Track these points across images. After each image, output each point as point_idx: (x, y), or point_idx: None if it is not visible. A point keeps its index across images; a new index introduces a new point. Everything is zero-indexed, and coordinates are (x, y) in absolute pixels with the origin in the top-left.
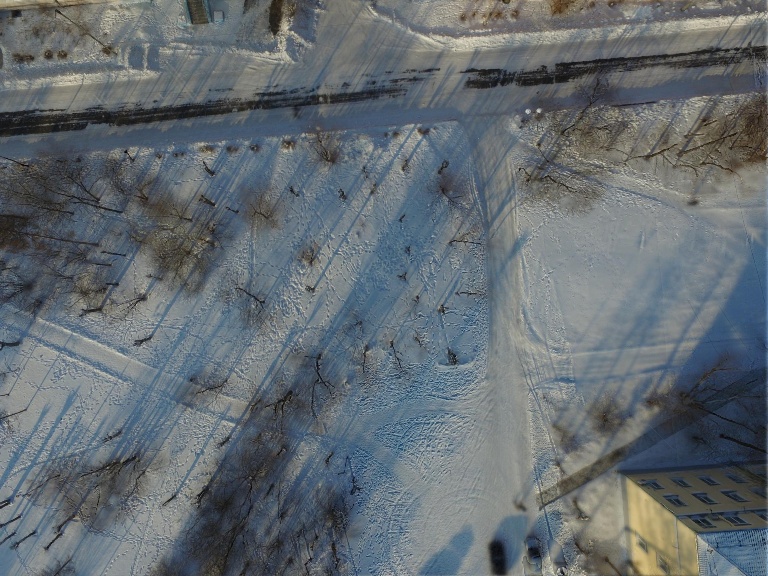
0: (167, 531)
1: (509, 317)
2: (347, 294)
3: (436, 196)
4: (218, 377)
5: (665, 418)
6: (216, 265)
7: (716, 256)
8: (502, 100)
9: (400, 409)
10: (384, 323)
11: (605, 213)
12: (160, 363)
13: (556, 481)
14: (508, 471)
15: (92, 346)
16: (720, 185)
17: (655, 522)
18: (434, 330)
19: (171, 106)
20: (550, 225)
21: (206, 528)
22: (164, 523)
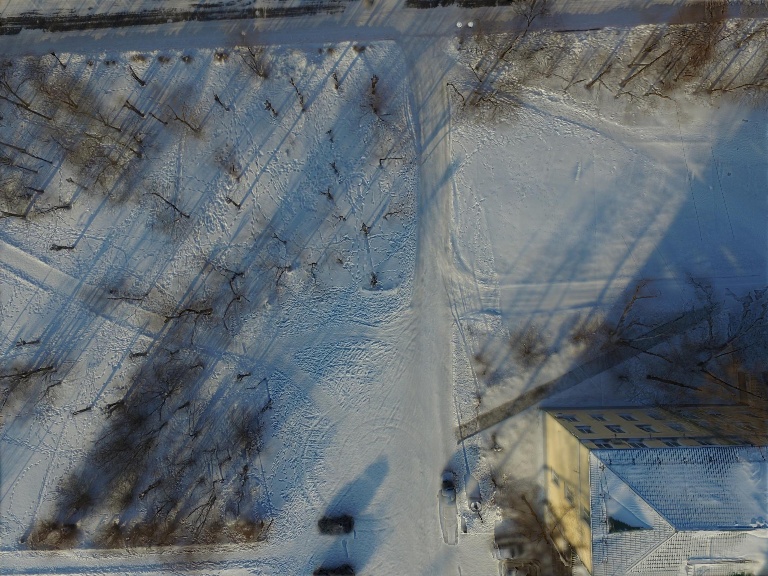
0: (80, 443)
1: (437, 245)
2: (273, 213)
3: (364, 112)
4: (139, 291)
5: (592, 356)
6: (142, 177)
7: (654, 192)
8: (442, 21)
9: (321, 333)
10: (309, 244)
11: (541, 142)
12: (81, 273)
13: (476, 415)
14: (428, 402)
15: (15, 253)
16: (662, 118)
17: (565, 452)
18: (359, 254)
19: (106, 14)
20: (484, 152)
21: (119, 442)
22: (78, 435)
